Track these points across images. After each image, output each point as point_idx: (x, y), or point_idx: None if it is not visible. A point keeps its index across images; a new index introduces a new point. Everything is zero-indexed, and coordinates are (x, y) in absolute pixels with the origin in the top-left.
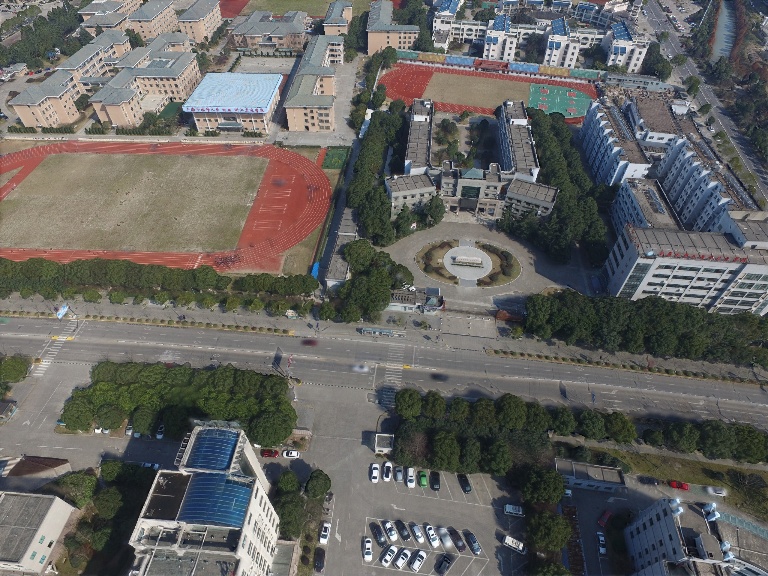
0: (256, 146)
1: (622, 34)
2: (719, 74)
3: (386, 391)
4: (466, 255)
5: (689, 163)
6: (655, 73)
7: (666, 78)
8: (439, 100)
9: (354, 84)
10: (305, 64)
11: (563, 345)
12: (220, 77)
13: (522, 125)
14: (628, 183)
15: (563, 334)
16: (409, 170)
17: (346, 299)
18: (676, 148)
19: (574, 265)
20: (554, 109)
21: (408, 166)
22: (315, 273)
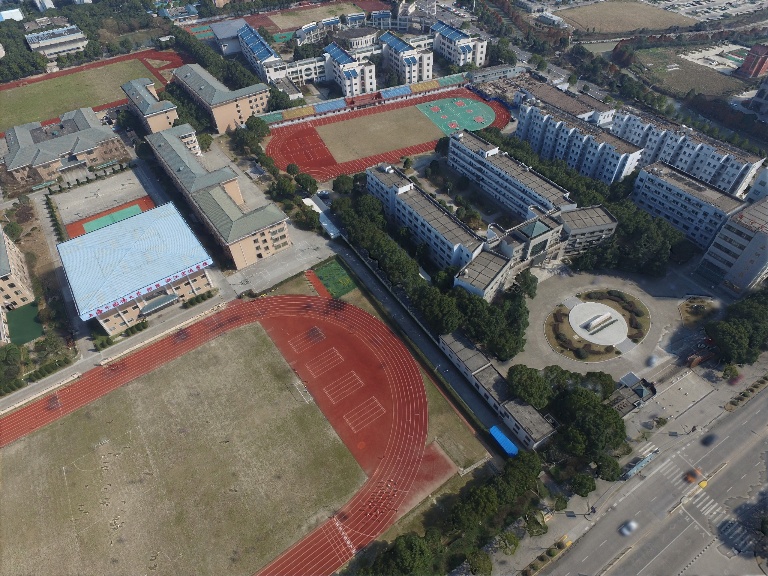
0: (220, 313)
1: (452, 33)
2: (542, 46)
3: (725, 530)
4: (588, 316)
5: (655, 134)
6: (499, 60)
7: (516, 62)
8: (357, 157)
9: (245, 175)
10: (188, 177)
11: (758, 357)
12: (87, 244)
13: (496, 154)
14: (649, 174)
15: (763, 348)
16: (458, 254)
17: (585, 453)
18: (624, 124)
19: (667, 271)
20: (465, 124)
21: (457, 251)
22: (507, 443)
